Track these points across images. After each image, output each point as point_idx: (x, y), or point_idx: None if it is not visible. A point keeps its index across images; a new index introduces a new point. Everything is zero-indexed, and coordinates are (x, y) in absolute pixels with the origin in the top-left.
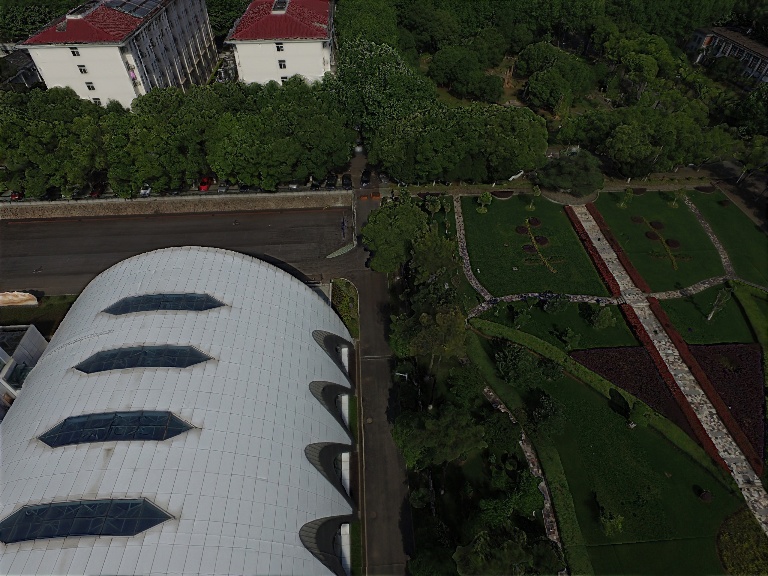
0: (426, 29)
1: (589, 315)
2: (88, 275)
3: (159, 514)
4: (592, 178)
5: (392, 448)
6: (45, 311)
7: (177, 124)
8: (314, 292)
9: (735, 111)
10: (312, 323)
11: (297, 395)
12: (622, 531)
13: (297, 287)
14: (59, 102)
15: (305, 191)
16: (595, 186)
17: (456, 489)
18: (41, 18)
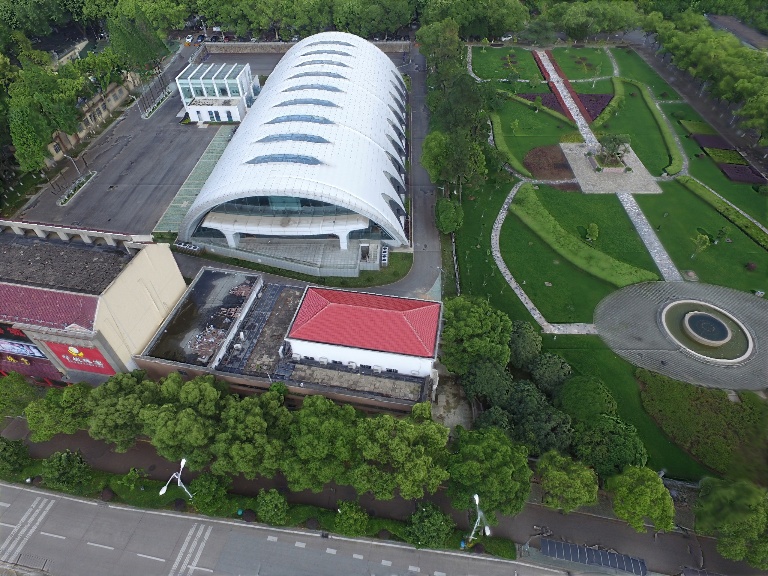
0: None
1: None
2: (271, 70)
3: (343, 77)
4: (549, 34)
5: (424, 117)
6: None
7: None
8: None
9: (653, 7)
10: (391, 68)
11: (386, 79)
12: (520, 133)
13: (384, 55)
14: None
15: (383, 41)
16: (551, 40)
17: None
18: None
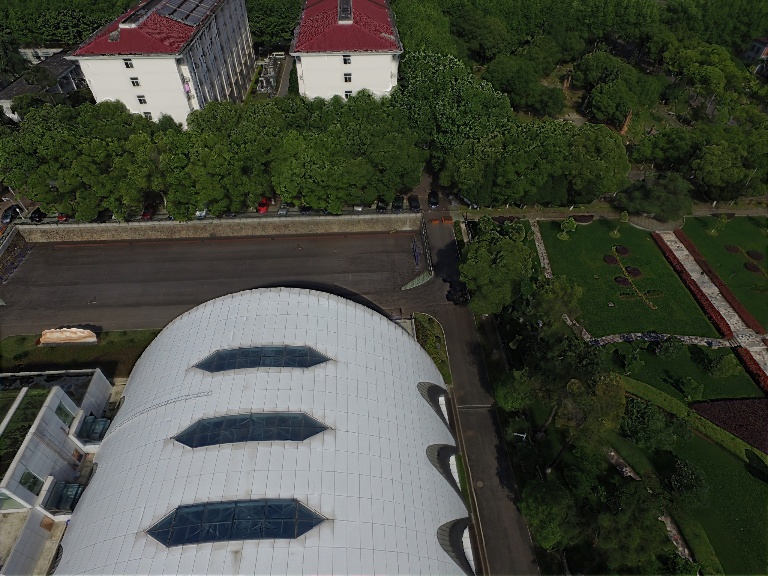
0: (475, 37)
1: (702, 360)
2: (147, 307)
3: None
4: (682, 203)
5: (511, 519)
6: (105, 349)
7: (239, 142)
8: (410, 336)
9: None
10: (415, 374)
11: (418, 466)
12: None
13: (395, 332)
14: (110, 117)
15: (372, 214)
16: (684, 211)
17: (595, 573)
18: (74, 23)
